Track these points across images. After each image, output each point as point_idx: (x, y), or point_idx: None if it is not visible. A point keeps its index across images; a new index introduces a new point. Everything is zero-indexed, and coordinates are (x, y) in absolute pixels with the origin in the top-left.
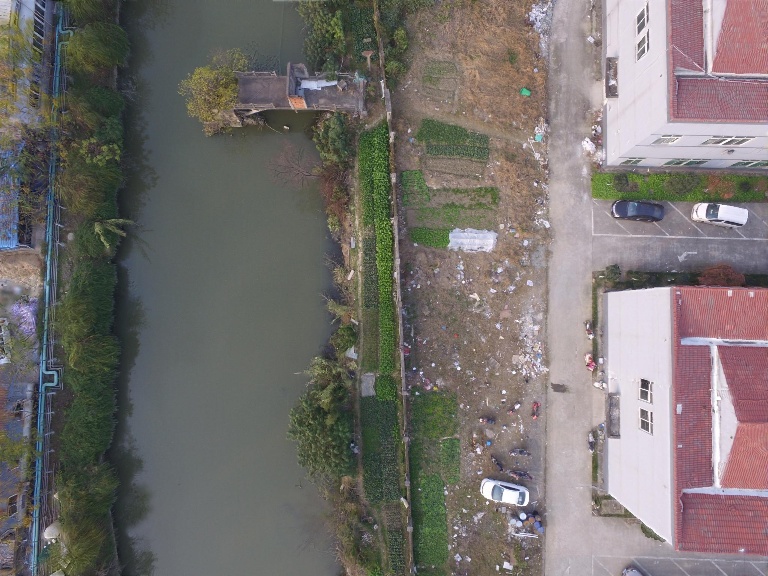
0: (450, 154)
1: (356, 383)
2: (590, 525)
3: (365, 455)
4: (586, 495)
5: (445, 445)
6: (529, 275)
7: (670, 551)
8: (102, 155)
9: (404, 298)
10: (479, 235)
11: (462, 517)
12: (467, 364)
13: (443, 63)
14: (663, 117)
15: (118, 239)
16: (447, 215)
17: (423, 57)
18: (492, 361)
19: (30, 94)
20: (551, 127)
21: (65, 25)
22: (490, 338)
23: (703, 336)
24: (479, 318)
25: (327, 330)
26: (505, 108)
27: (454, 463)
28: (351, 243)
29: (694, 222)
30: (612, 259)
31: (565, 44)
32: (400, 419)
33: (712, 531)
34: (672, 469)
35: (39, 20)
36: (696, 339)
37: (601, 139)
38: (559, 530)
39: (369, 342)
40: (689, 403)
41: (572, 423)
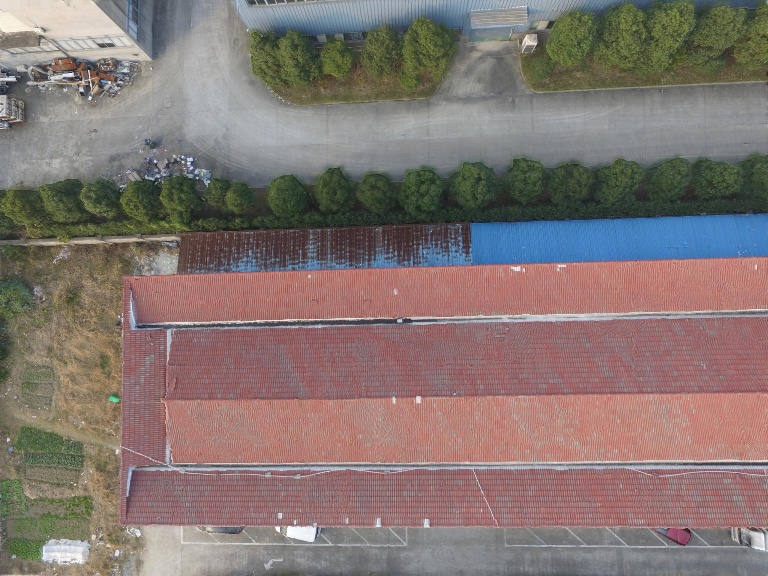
0: (46, 463)
1: None
2: None
3: None
4: None
5: None
6: None
7: None
8: None
9: None
10: (71, 548)
11: None
12: None
13: (41, 368)
14: None
15: None
16: (43, 526)
17: (23, 362)
18: None
19: None
20: None
21: None
22: None
23: None
24: None
25: None
26: (98, 414)
27: None
28: None
29: None
30: (200, 568)
31: None
32: None
33: None
34: None
35: None
36: None
37: None
38: None
39: None
40: None
41: None
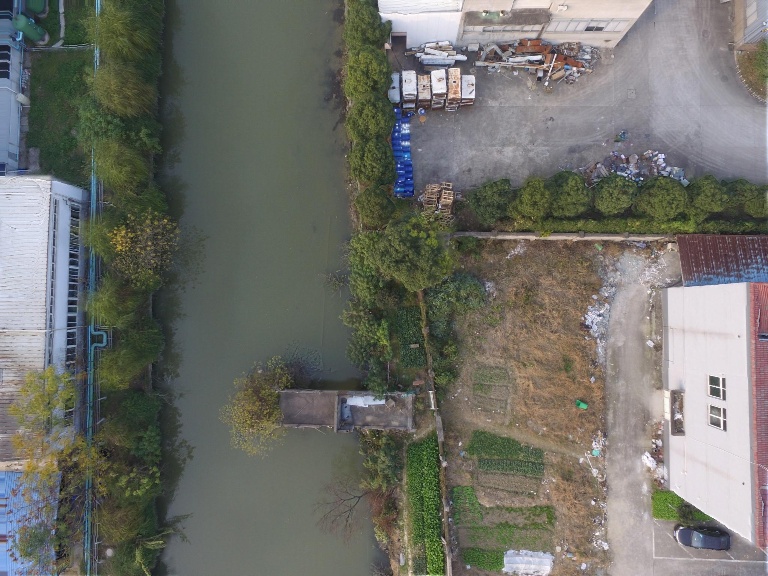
0: (503, 470)
1: None
2: None
3: None
4: None
5: None
6: None
7: None
8: (142, 488)
9: None
10: (535, 560)
11: None
12: None
13: (494, 369)
14: (746, 532)
15: (158, 550)
16: (501, 536)
17: (473, 362)
18: None
19: (65, 415)
20: (609, 439)
21: (97, 324)
22: None
23: None
24: None
25: None
26: (560, 420)
27: None
28: (400, 560)
29: None
30: None
31: (623, 348)
32: None
33: None
34: None
35: (71, 330)
36: None
37: (662, 454)
38: None
39: None
40: None
41: None
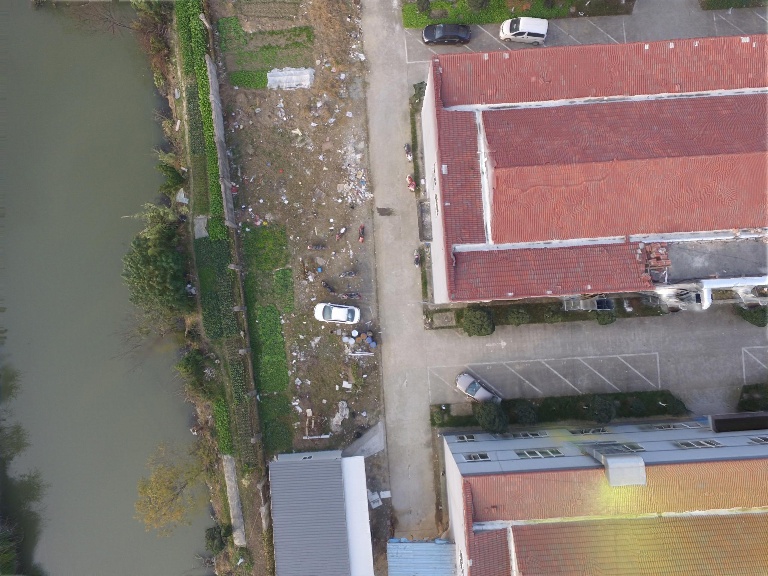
0: None
1: (189, 226)
2: (423, 339)
3: (202, 294)
4: (418, 311)
5: (278, 276)
6: (348, 107)
7: (501, 355)
8: None
9: (229, 140)
10: (296, 72)
11: (299, 343)
12: (294, 197)
13: None
14: None
15: None
16: (265, 57)
17: None
18: (318, 192)
19: None
20: None
21: None
22: (314, 170)
23: (468, 103)
24: (302, 152)
25: (161, 183)
26: None
27: (288, 292)
28: (175, 94)
29: (503, 42)
30: None
31: None
32: (234, 257)
33: (480, 277)
34: (444, 228)
35: None
36: (462, 107)
37: None
38: (394, 346)
39: (198, 186)
40: (456, 164)
41: (399, 244)
